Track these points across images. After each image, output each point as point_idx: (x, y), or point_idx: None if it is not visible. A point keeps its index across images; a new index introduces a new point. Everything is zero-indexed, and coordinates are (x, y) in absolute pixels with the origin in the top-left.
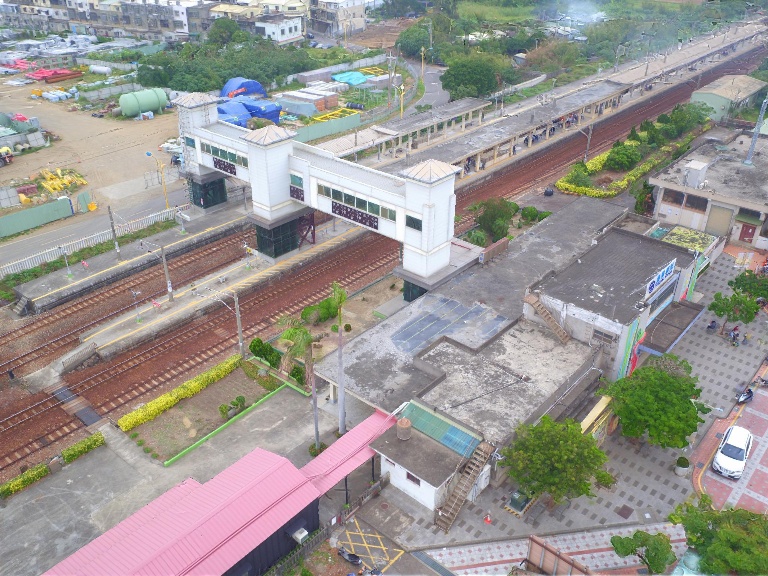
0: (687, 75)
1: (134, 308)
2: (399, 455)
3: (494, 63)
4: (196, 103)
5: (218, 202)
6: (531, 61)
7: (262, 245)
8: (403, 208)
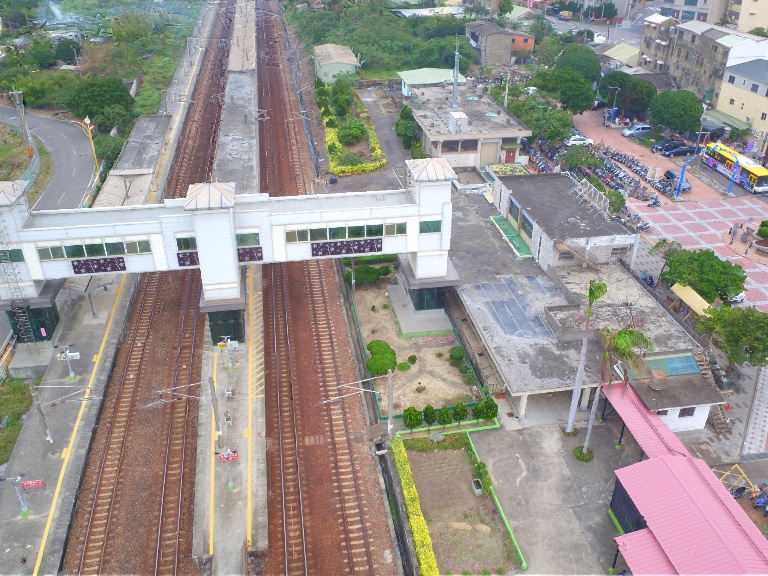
0: (286, 52)
1: (171, 488)
2: (675, 401)
3: (81, 79)
4: (13, 196)
5: (54, 325)
6: (92, 71)
7: (221, 335)
8: (416, 216)
